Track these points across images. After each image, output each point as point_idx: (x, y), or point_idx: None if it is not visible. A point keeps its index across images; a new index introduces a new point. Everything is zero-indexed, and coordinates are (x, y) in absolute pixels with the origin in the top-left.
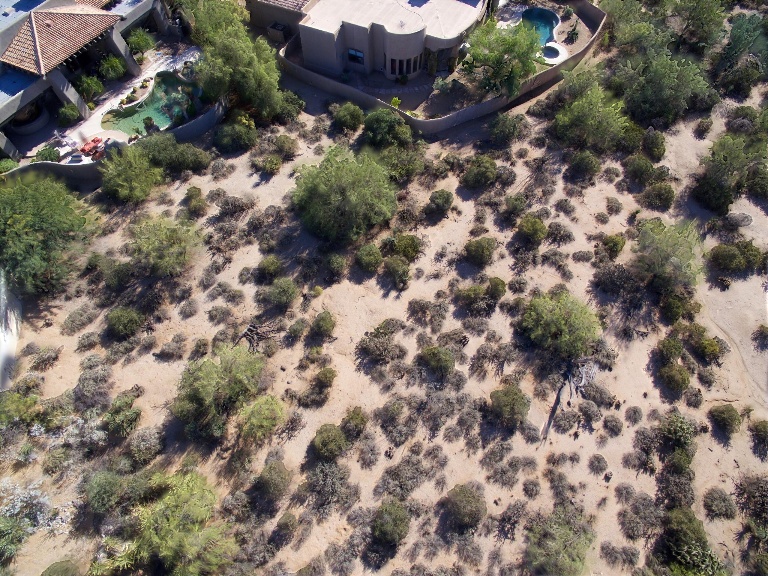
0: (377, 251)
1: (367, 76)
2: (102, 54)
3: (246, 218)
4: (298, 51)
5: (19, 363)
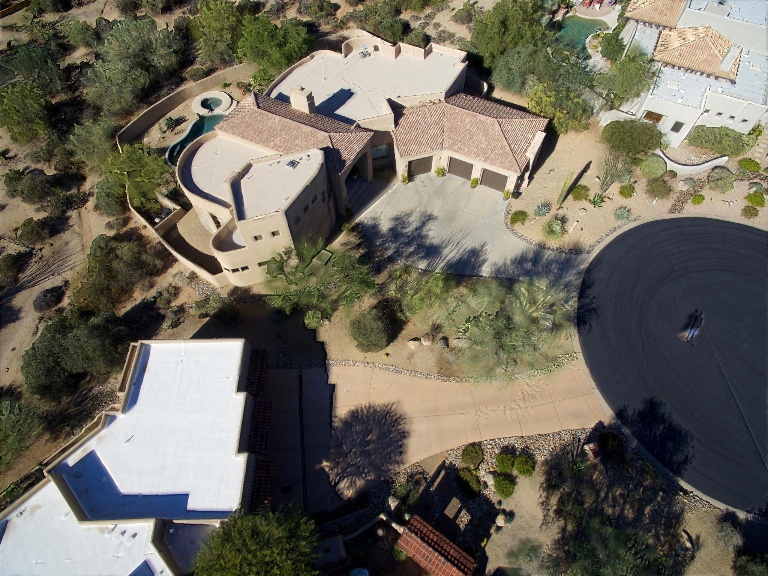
0: None
1: None
2: None
3: None
4: None
5: None
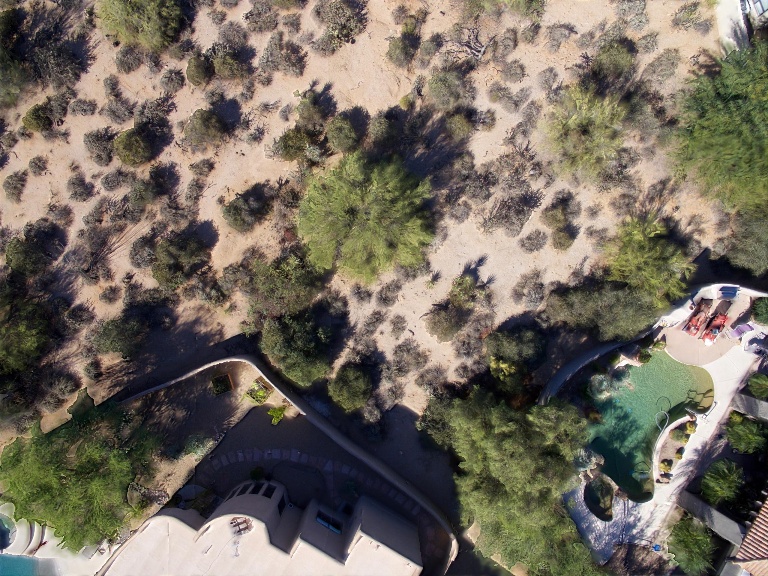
0: (332, 133)
1: (317, 492)
2: (749, 513)
3: (493, 204)
4: (429, 569)
5: (711, 11)
